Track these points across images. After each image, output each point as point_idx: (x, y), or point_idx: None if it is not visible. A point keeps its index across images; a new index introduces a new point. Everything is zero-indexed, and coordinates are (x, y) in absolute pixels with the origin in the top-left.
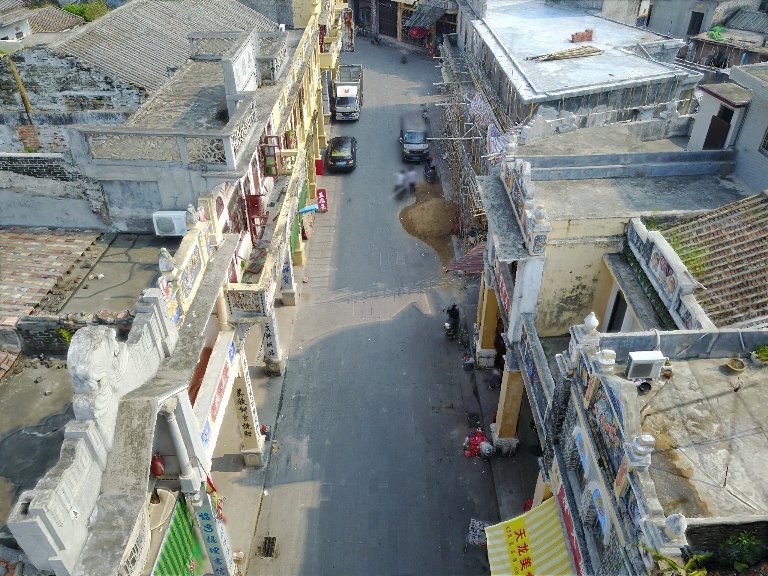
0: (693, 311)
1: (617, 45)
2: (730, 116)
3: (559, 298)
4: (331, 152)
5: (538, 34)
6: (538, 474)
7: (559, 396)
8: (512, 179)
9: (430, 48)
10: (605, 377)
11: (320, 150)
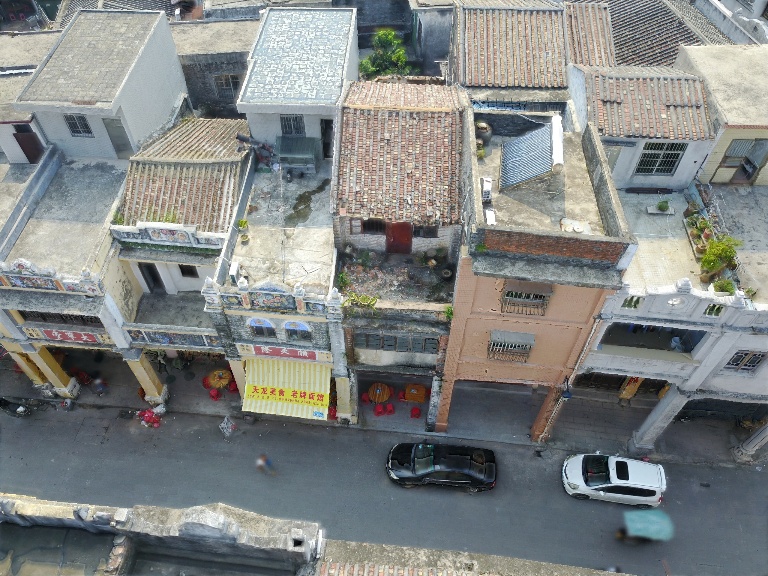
0: (210, 237)
1: None
2: (29, 128)
3: (122, 300)
4: None
5: None
6: (189, 383)
7: (221, 322)
8: (5, 278)
9: None
10: (254, 288)
11: None
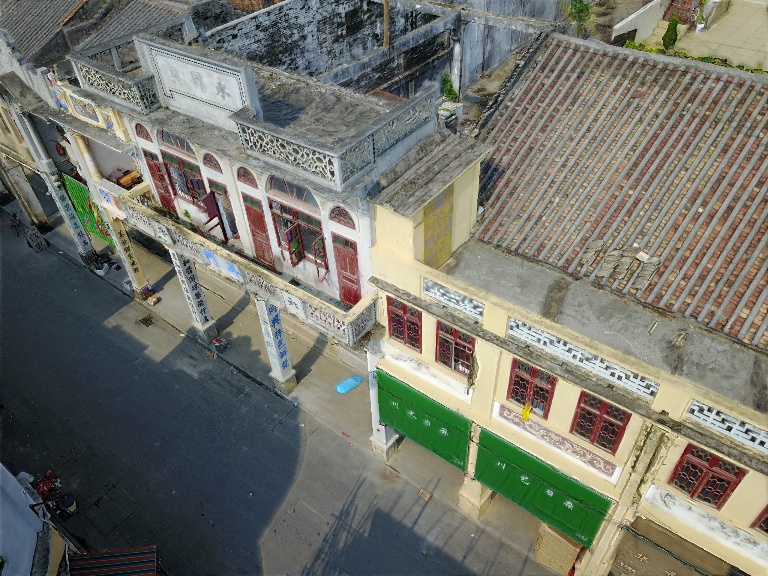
0: None
1: None
2: None
3: None
4: None
5: None
6: None
7: None
8: None
9: None
10: None
11: None
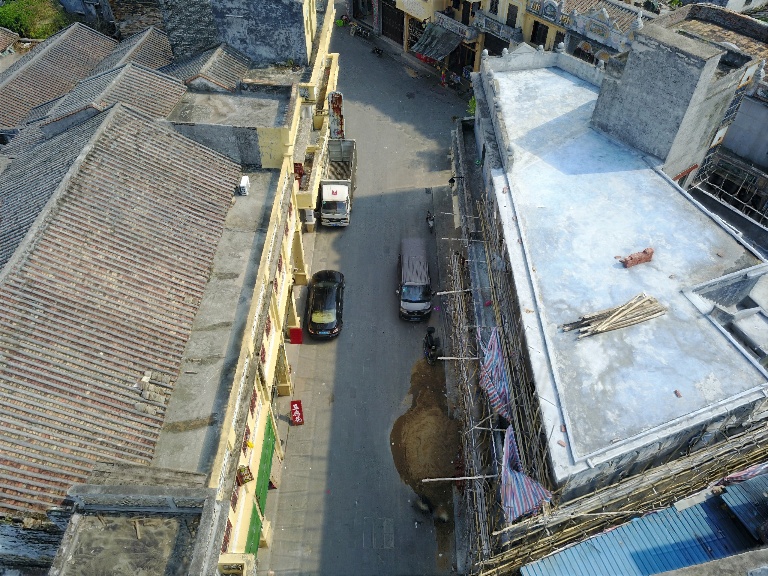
0: None
1: (685, 279)
2: None
3: None
4: (311, 315)
5: (579, 234)
6: None
7: None
8: None
9: (442, 77)
10: None
11: (300, 288)
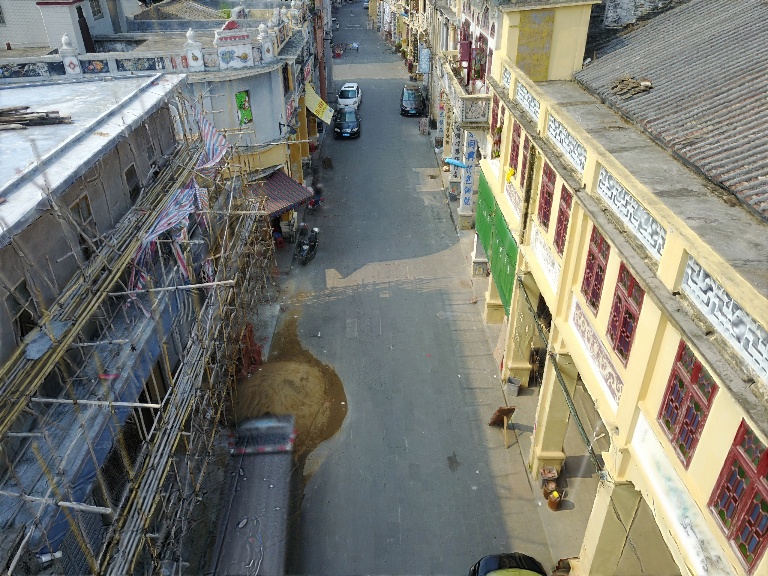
0: None
1: None
2: None
3: None
4: None
5: None
6: None
7: None
8: None
9: None
10: None
11: None
